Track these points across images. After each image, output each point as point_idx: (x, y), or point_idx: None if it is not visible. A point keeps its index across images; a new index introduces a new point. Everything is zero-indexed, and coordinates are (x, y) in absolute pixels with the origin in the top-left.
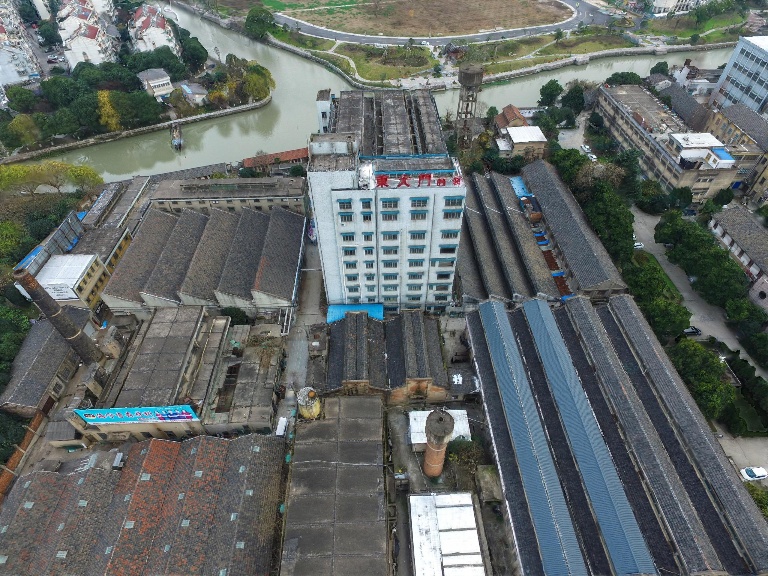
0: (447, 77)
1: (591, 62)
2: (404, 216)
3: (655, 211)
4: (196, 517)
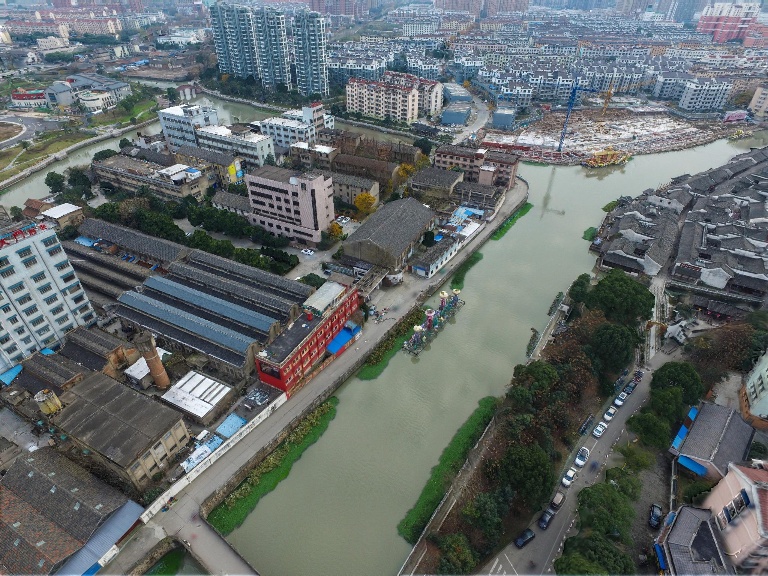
0: None
1: (70, 156)
2: (19, 267)
3: (183, 215)
4: (22, 518)
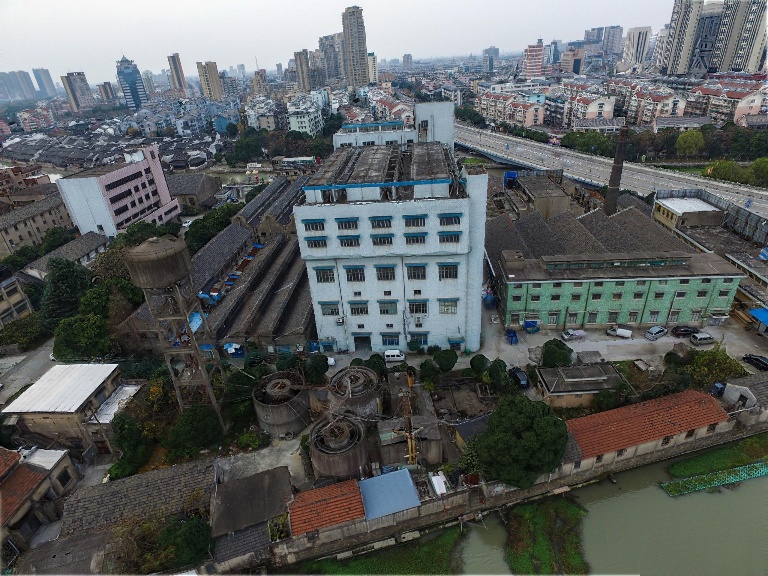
0: None
1: None
2: None
3: None
4: None
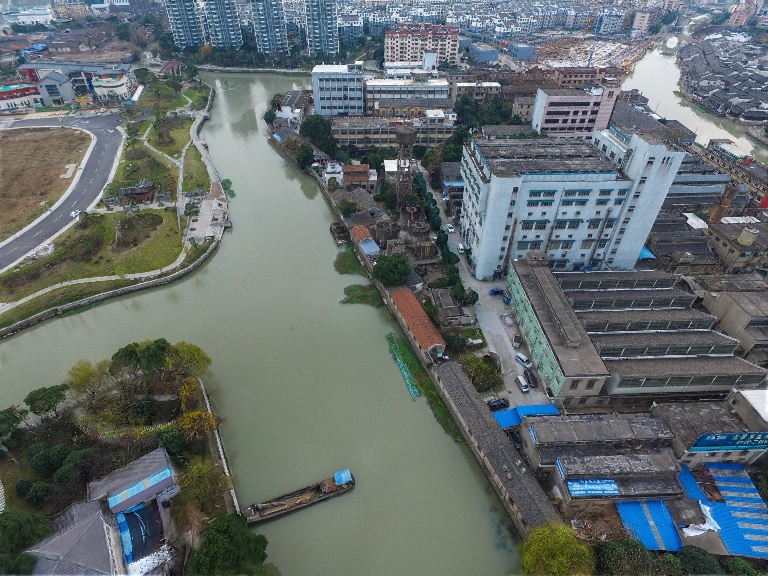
0: (202, 207)
1: None
2: None
3: None
4: None
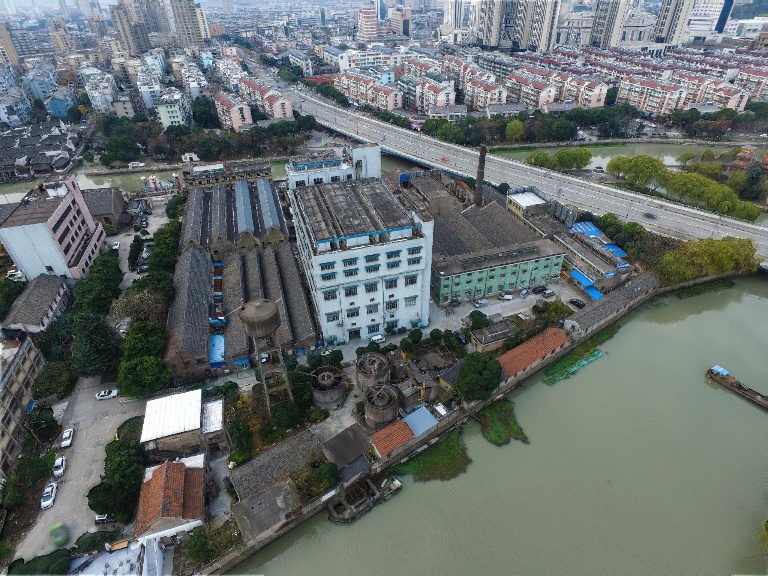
0: None
1: None
2: None
3: None
4: None
